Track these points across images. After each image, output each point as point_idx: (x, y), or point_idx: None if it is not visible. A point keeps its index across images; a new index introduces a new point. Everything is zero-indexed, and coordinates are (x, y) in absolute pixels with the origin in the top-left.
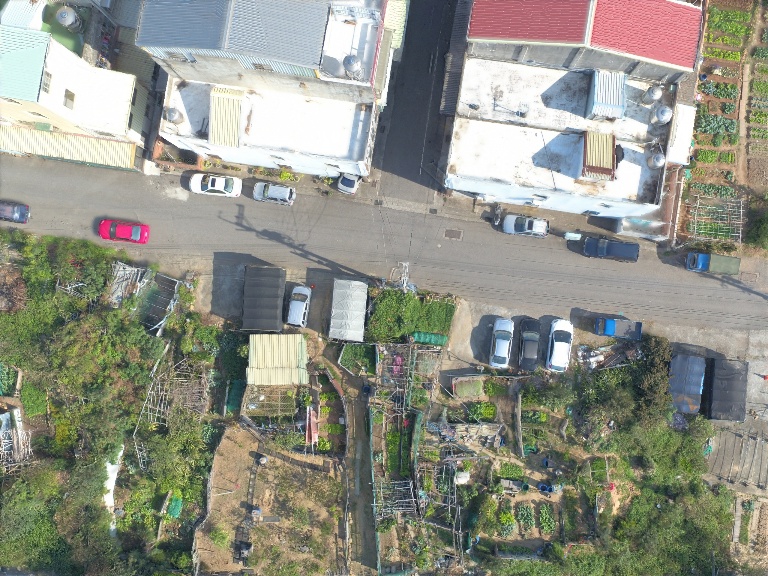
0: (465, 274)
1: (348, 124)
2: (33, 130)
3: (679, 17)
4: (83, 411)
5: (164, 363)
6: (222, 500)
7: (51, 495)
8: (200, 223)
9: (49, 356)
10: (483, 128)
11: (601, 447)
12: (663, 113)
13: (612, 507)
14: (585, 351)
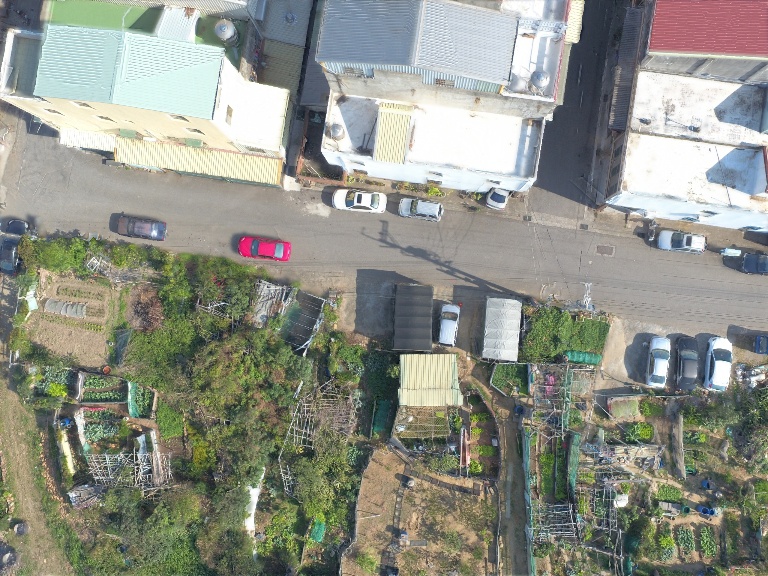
0: (618, 291)
1: (514, 139)
2: (176, 146)
3: None
4: (225, 433)
5: (309, 384)
6: (367, 524)
7: (191, 519)
8: (343, 240)
9: (192, 377)
10: (654, 143)
11: (763, 468)
12: None
13: None
14: (744, 370)
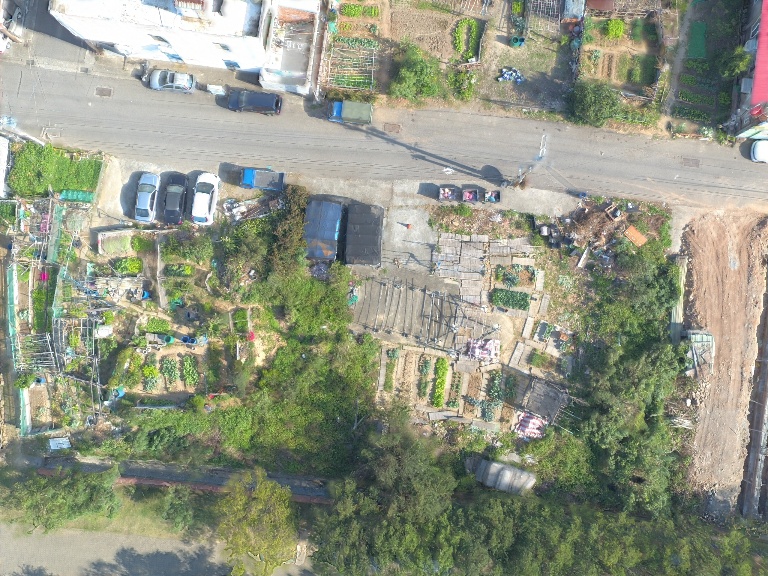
0: (115, 131)
1: None
2: None
3: None
4: None
5: None
6: None
7: None
8: None
9: None
10: None
11: (244, 297)
12: None
13: (255, 357)
14: (230, 203)
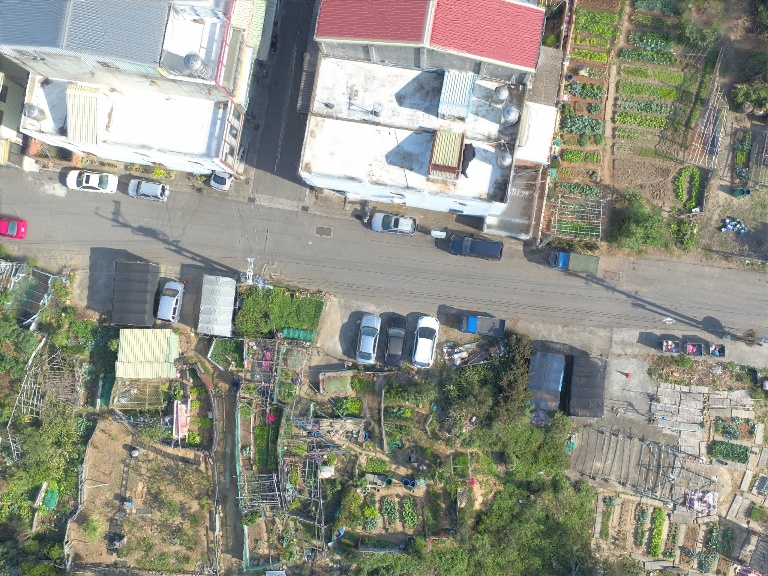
0: (335, 271)
1: (206, 122)
2: None
3: (522, 18)
4: None
5: (39, 356)
6: (96, 492)
7: None
8: (77, 219)
9: None
10: (338, 127)
11: (464, 443)
12: (509, 113)
13: (474, 502)
14: (450, 348)
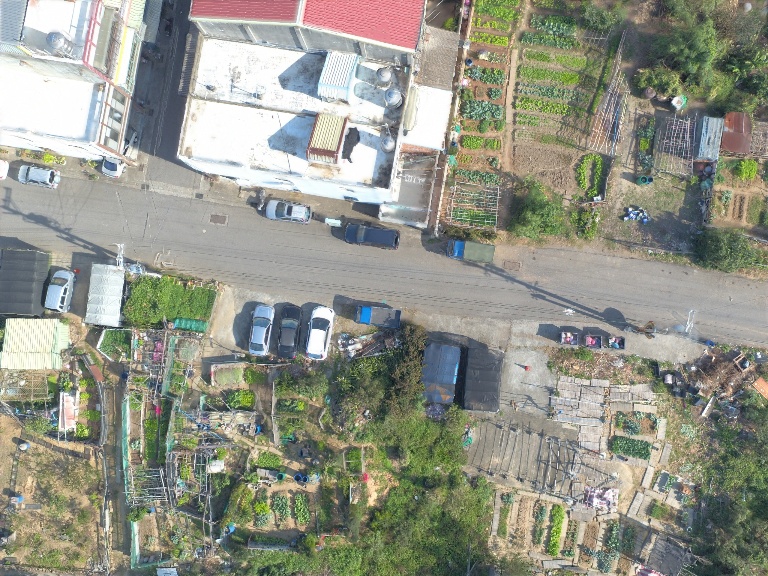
0: (229, 260)
1: (85, 104)
2: None
3: None
4: None
5: None
6: None
7: None
8: None
9: None
10: (220, 110)
11: (357, 437)
12: (390, 95)
13: (367, 498)
14: (345, 339)
